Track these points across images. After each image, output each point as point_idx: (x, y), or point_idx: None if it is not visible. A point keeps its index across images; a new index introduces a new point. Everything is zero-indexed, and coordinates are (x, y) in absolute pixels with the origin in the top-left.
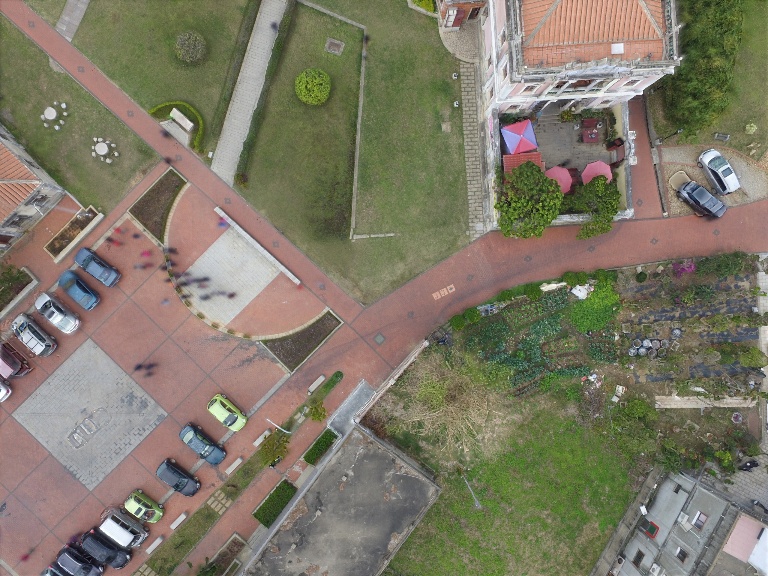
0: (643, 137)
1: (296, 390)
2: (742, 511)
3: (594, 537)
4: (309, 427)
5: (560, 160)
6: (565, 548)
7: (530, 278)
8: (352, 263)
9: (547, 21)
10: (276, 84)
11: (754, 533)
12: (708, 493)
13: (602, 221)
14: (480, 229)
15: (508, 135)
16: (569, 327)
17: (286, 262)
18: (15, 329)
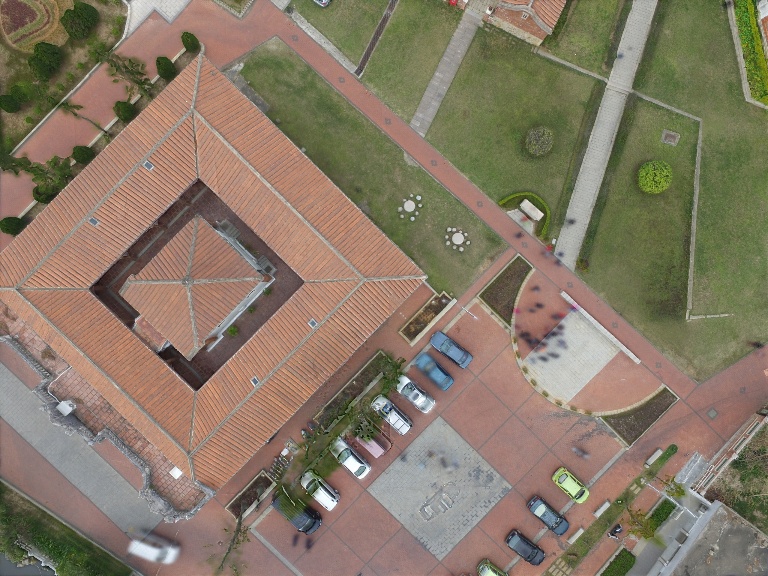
0: None
1: (632, 463)
2: None
3: None
4: (644, 497)
5: None
6: None
7: None
8: (687, 342)
9: None
10: (616, 174)
11: None
12: None
13: None
14: None
15: None
16: None
17: (625, 342)
18: (378, 410)
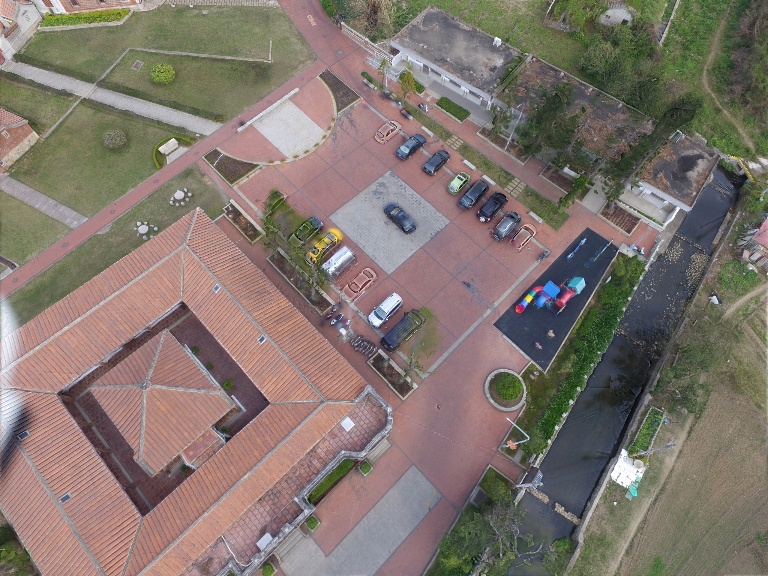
0: None
1: (373, 97)
2: None
3: None
4: None
5: None
6: None
7: None
8: (288, 63)
9: None
10: None
11: None
12: None
13: None
14: (273, 2)
15: None
16: None
17: None
18: (316, 259)
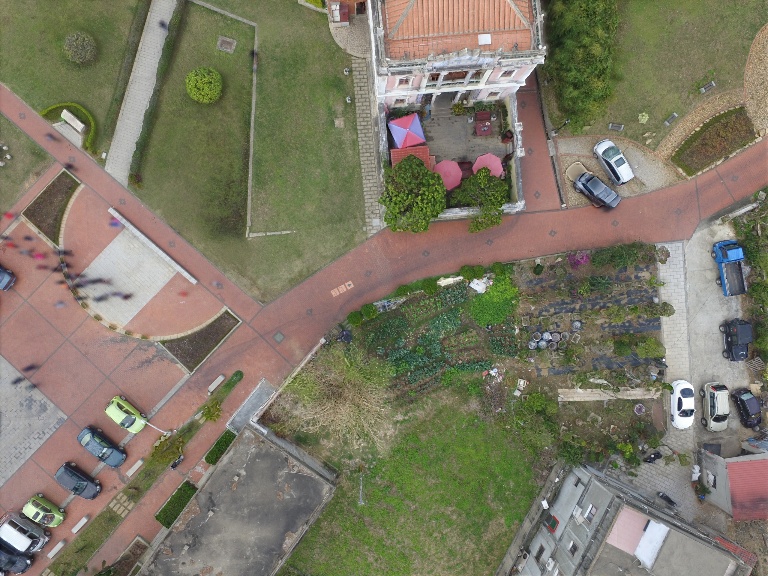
0: (539, 129)
1: (196, 390)
2: (624, 503)
3: (500, 533)
4: (210, 427)
5: (455, 154)
6: (471, 544)
7: (428, 273)
8: (249, 261)
9: (409, 13)
10: (168, 83)
11: (640, 525)
12: (600, 486)
13: (491, 214)
14: (377, 225)
15: (395, 129)
16: (469, 321)
17: (183, 262)
18: None
